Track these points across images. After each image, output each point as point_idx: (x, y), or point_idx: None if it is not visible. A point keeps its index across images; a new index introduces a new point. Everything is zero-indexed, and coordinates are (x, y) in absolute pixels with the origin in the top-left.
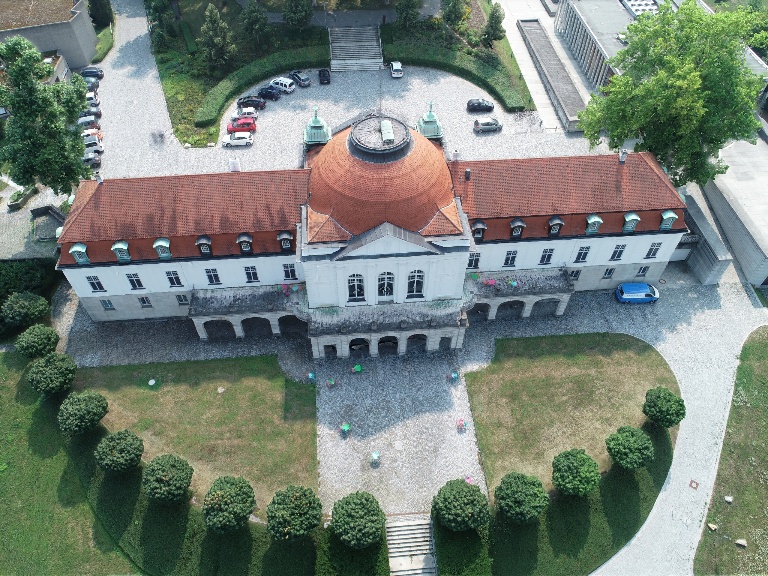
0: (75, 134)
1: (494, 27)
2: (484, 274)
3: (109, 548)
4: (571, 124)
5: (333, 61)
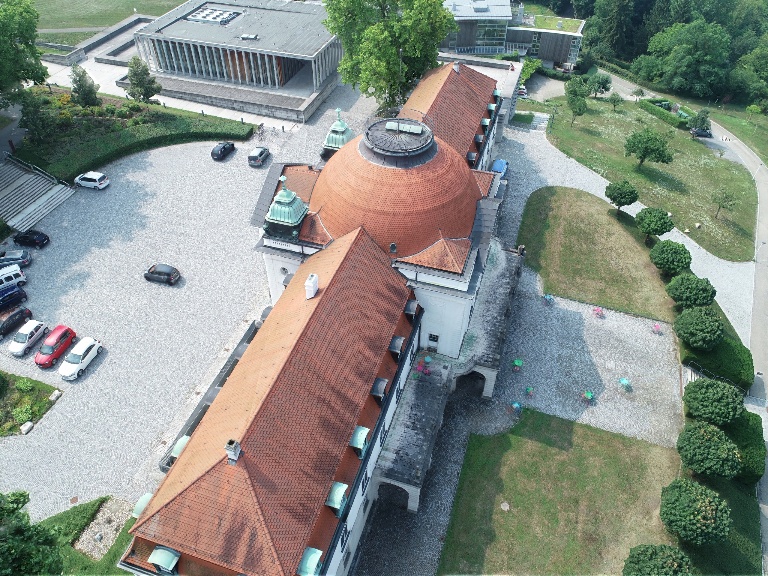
0: None
1: (146, 83)
2: None
3: None
4: (304, 113)
5: (9, 222)
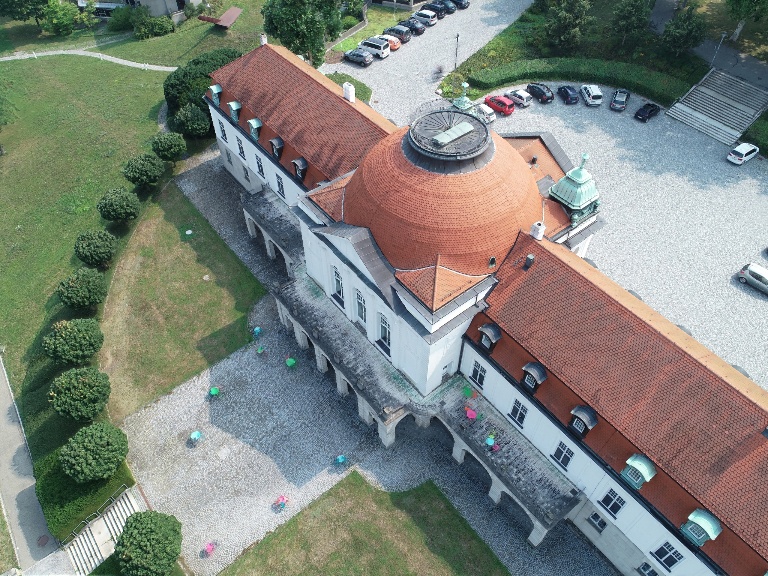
0: (326, 13)
1: None
2: (484, 402)
3: (49, 306)
4: None
5: (680, 104)
